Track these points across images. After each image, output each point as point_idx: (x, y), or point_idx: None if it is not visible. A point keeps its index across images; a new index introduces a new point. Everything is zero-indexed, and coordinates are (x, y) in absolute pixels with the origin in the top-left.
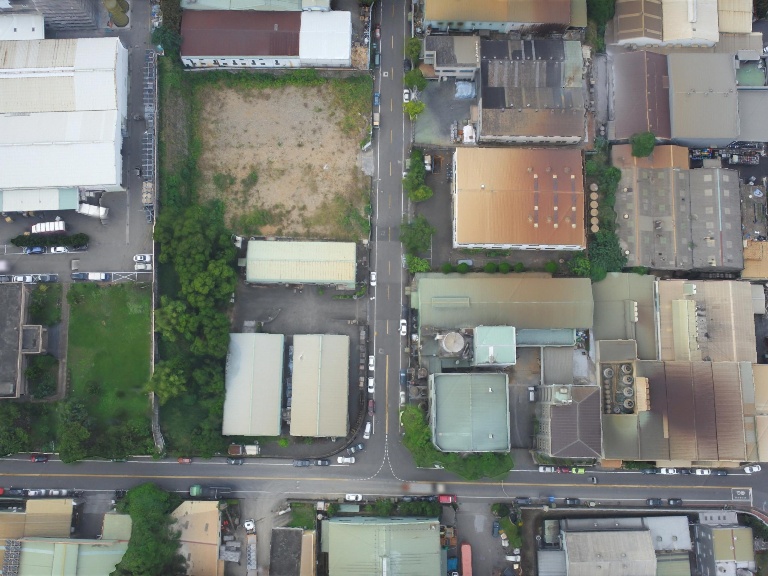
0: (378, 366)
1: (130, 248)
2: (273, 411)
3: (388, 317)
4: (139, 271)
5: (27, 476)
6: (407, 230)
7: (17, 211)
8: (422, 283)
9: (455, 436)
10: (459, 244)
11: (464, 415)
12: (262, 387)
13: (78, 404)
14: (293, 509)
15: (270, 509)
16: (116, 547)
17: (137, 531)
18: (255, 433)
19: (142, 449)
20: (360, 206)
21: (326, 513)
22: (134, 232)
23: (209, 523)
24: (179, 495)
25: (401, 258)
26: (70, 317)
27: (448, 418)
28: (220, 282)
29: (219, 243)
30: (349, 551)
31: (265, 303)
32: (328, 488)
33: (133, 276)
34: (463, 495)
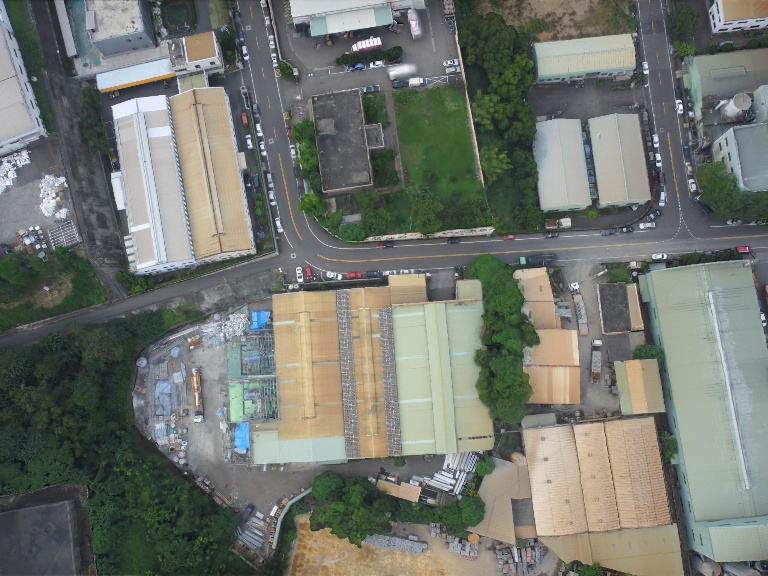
0: (661, 143)
1: (438, 56)
2: (583, 184)
3: (664, 100)
4: (450, 74)
5: (378, 261)
6: (678, 15)
7: (340, 32)
8: (697, 61)
9: (760, 178)
10: (723, 24)
11: (766, 159)
12: (571, 164)
13: (424, 186)
14: (608, 271)
15: (588, 273)
16: (474, 305)
17: (499, 282)
18: (572, 203)
19: (483, 220)
20: (624, 6)
21: (640, 270)
22: (439, 42)
23: (542, 285)
24: (511, 265)
25: (667, 47)
26: (396, 120)
27: (751, 164)
28: (523, 75)
29: (518, 41)
30: (674, 293)
31: (552, 100)
32: (635, 252)
33: (445, 79)
34: (756, 246)
